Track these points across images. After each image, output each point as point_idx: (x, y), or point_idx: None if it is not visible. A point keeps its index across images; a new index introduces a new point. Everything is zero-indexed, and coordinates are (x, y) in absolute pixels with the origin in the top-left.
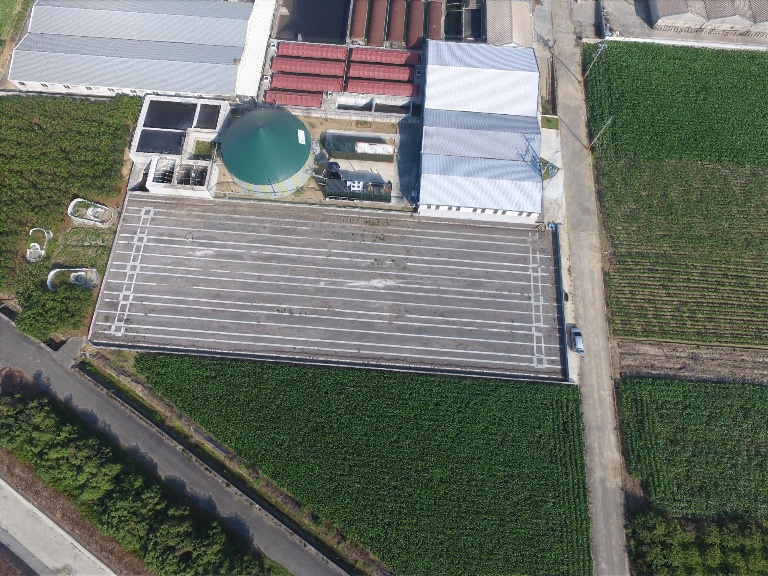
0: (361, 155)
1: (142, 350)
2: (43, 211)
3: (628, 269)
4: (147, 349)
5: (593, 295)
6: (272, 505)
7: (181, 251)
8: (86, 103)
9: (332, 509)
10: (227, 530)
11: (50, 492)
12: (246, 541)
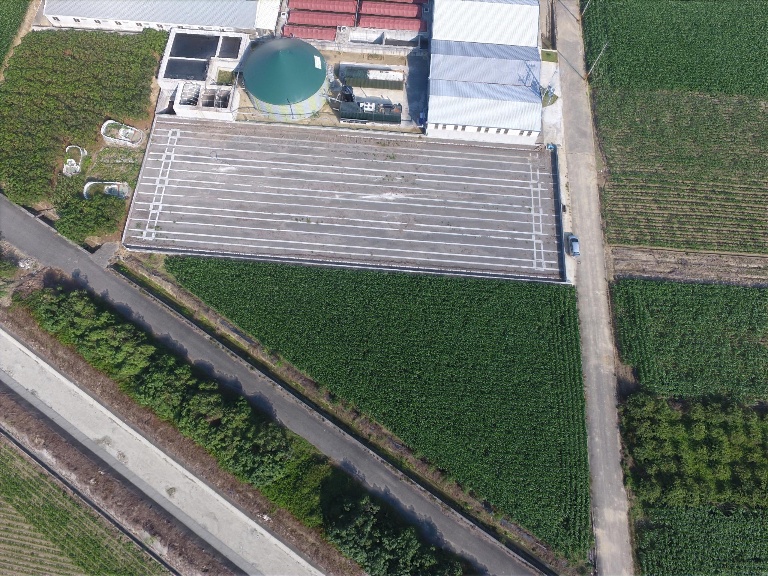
0: (373, 82)
1: (172, 252)
2: (79, 129)
3: (622, 186)
4: (176, 251)
5: (589, 208)
6: (293, 388)
7: (206, 167)
8: (116, 35)
9: (348, 388)
10: (252, 406)
11: (91, 371)
12: (269, 416)
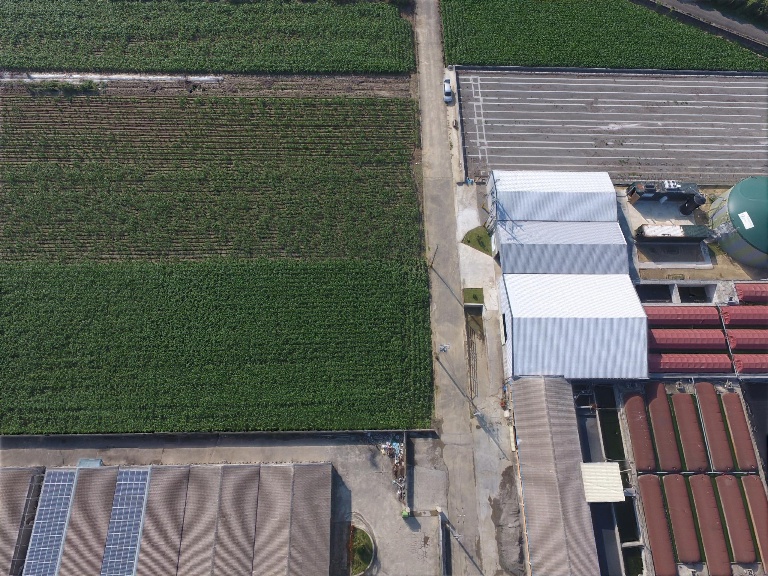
0: None
1: None
2: None
3: None
4: None
5: (431, 127)
6: None
7: None
8: None
9: None
10: None
11: None
12: None
